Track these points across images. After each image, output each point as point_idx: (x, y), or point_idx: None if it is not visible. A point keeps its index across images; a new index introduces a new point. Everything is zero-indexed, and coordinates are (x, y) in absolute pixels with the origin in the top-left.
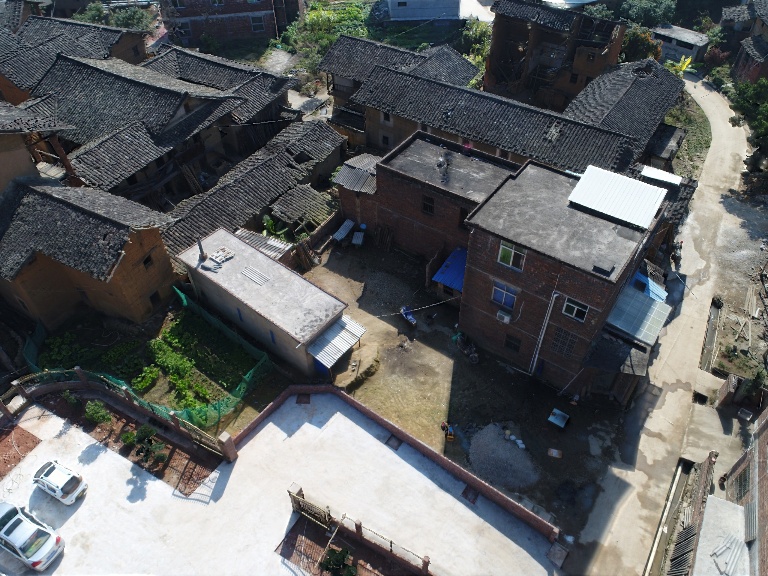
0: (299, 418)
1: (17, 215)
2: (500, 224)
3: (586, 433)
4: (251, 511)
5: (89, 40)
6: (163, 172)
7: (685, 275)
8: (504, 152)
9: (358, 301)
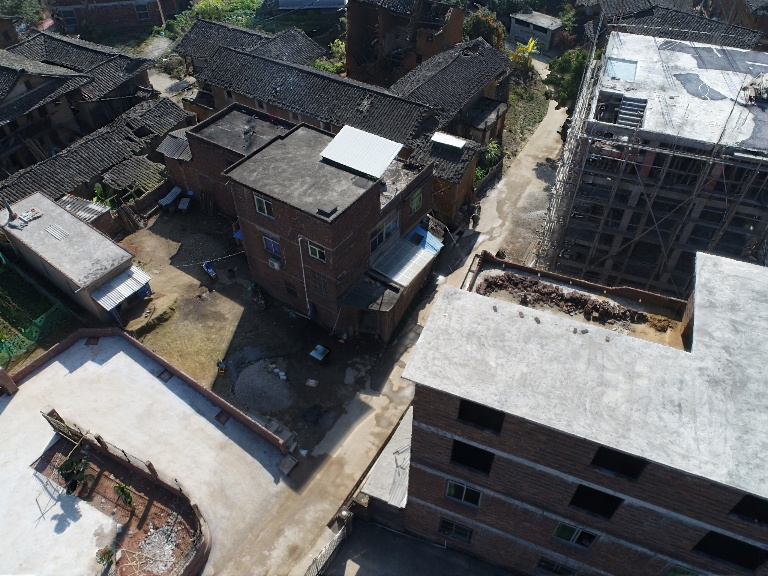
0: (84, 357)
1: None
2: (253, 176)
3: (345, 366)
4: (18, 434)
5: None
6: (6, 145)
7: (479, 232)
8: (327, 124)
9: (171, 259)
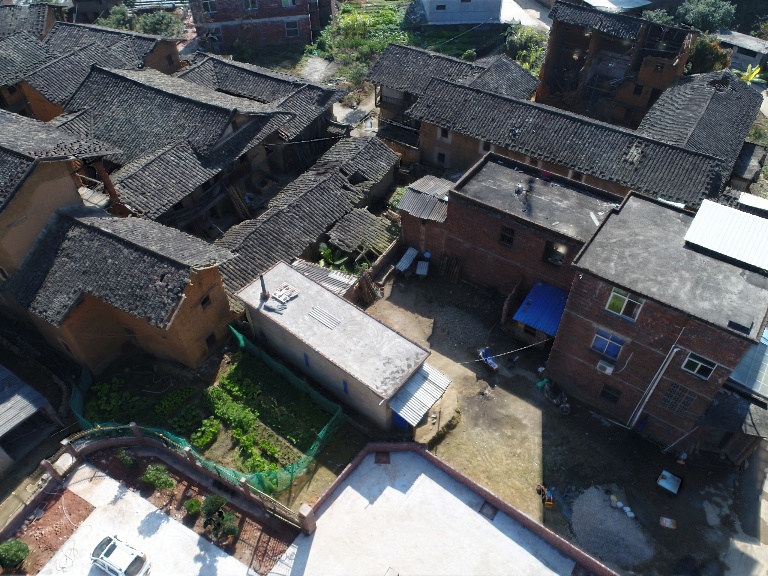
0: (380, 481)
1: (62, 251)
2: (612, 268)
3: (700, 498)
4: None
5: (122, 49)
6: (209, 195)
7: None
8: (577, 173)
9: (429, 340)
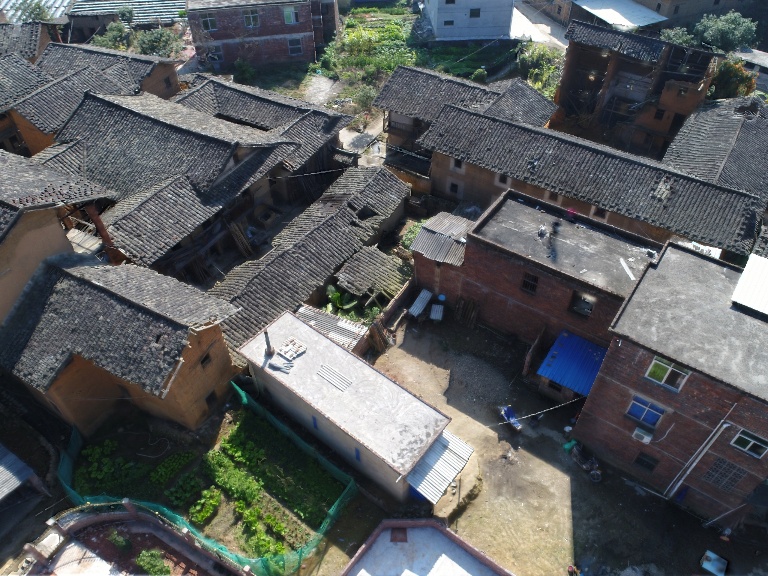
0: (397, 563)
1: (49, 305)
2: (653, 334)
3: None
4: None
5: (117, 72)
6: (209, 232)
7: None
8: (600, 209)
9: (446, 395)
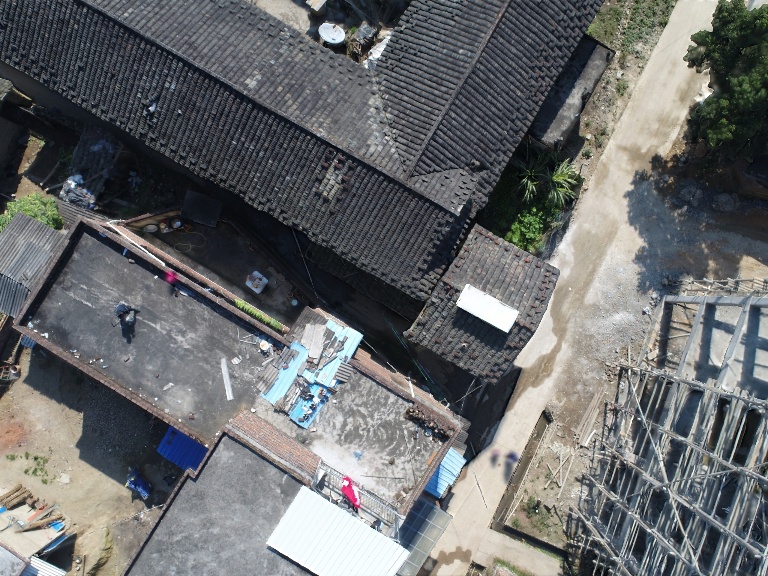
0: None
1: None
2: None
3: None
4: None
5: None
6: None
7: (520, 369)
8: None
9: (78, 446)
